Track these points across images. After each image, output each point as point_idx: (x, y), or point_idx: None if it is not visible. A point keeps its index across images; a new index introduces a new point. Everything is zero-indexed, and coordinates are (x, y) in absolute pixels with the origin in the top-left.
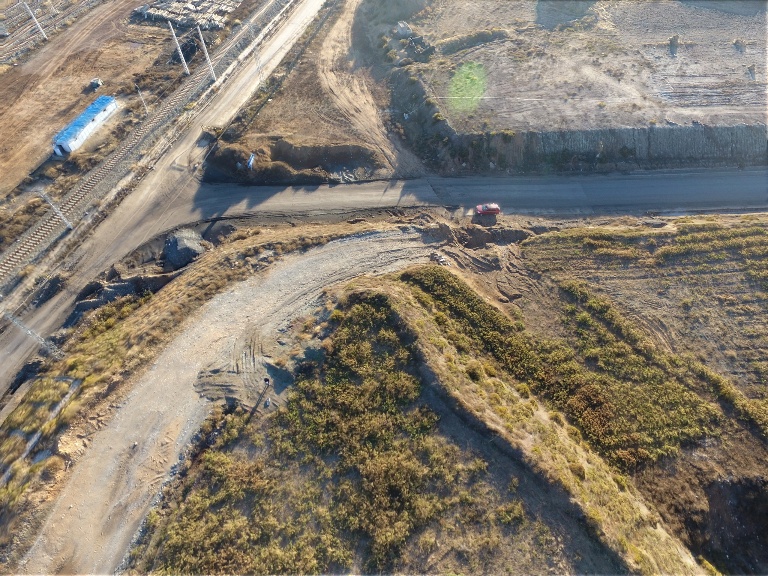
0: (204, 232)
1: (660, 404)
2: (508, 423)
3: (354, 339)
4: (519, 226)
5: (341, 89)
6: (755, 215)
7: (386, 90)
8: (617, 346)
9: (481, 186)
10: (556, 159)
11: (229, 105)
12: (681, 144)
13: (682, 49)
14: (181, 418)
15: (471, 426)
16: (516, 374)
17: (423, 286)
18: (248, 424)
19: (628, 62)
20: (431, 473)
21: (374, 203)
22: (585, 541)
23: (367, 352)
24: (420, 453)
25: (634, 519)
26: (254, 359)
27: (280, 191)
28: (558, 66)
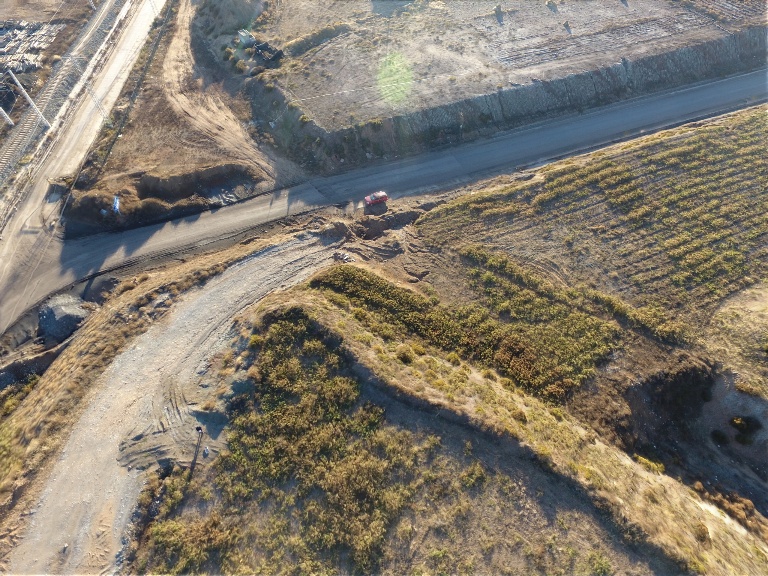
0: (83, 293)
1: (570, 335)
2: (448, 394)
3: (280, 359)
4: (409, 207)
5: (196, 110)
6: (601, 151)
7: (244, 102)
8: (522, 294)
9: (364, 178)
10: (426, 137)
11: (74, 150)
12: (528, 101)
13: (507, 17)
14: (112, 500)
15: (416, 407)
16: (443, 346)
17: (334, 288)
18: (191, 480)
19: (465, 36)
20: (391, 465)
21: (263, 218)
22: (542, 477)
23: (296, 368)
24: (375, 449)
25: (576, 442)
26: (179, 411)
27: (159, 229)
28: (404, 50)
